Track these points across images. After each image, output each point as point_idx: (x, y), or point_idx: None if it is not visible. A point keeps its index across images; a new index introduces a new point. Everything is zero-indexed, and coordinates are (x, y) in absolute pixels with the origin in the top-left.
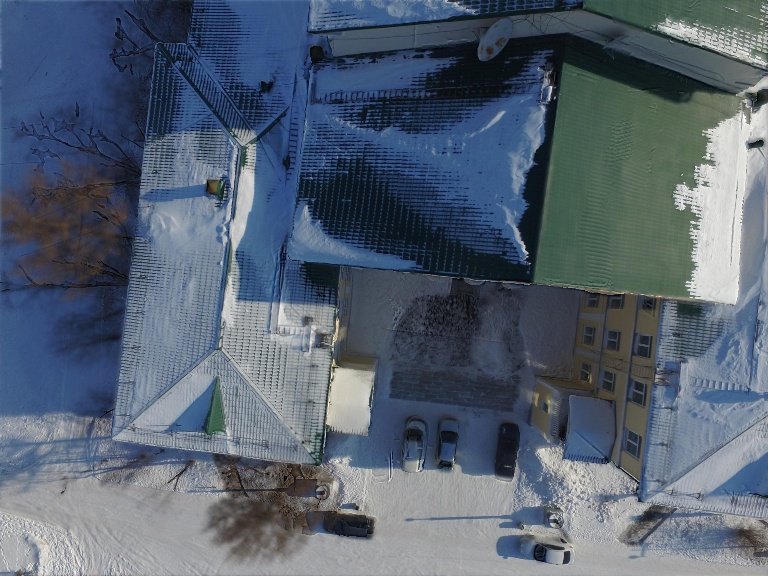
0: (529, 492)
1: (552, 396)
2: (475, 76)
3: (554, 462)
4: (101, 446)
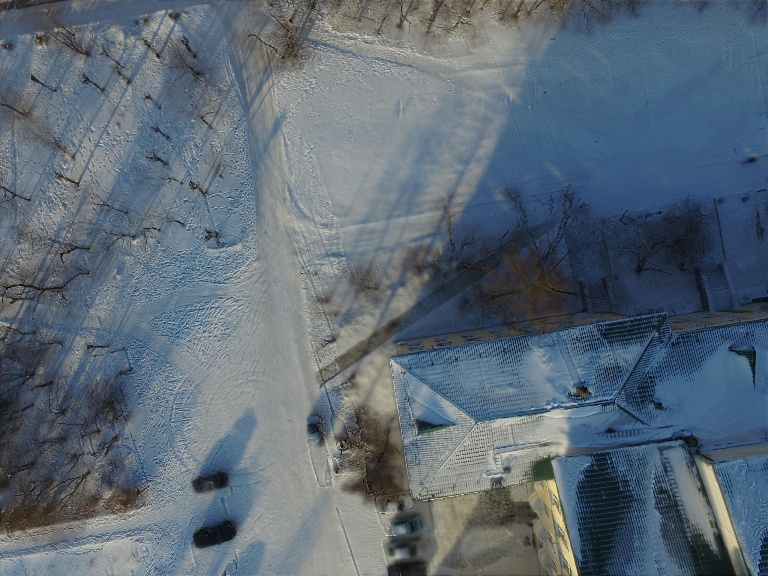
0: None
1: None
2: (710, 570)
3: None
4: (326, 267)
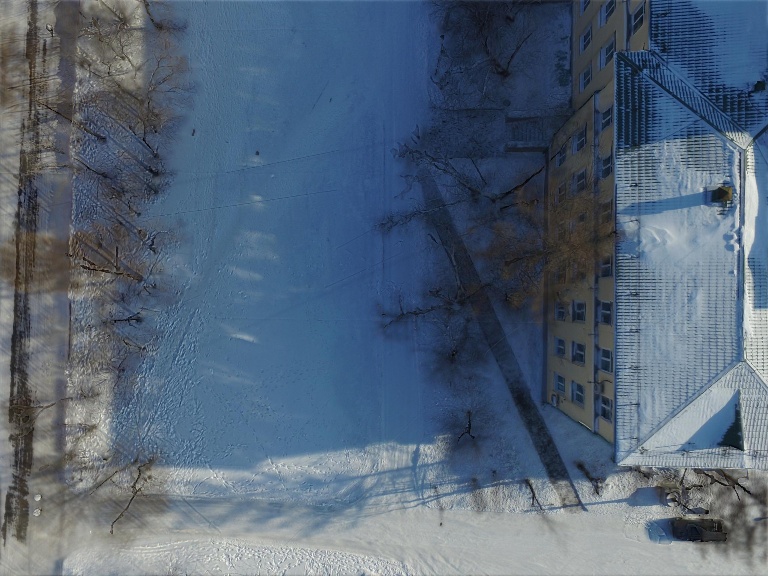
0: None
1: None
2: None
3: None
4: (428, 473)
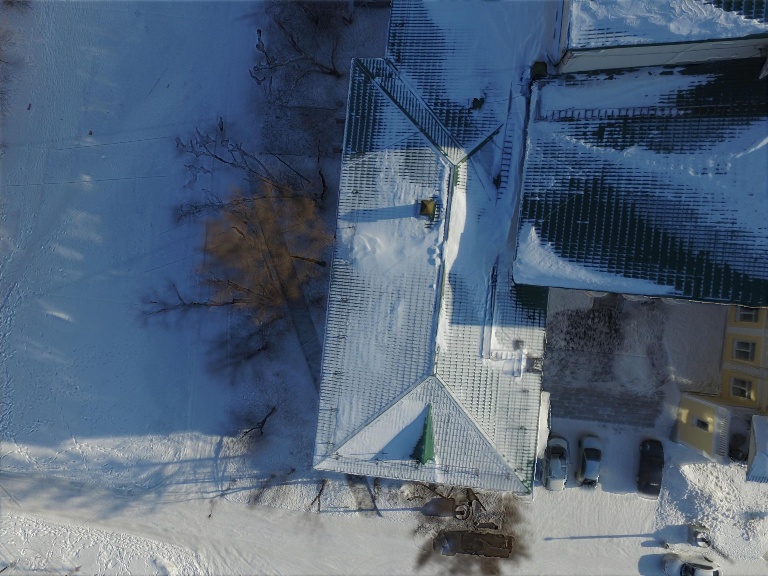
0: (672, 510)
1: (716, 414)
2: (739, 94)
3: (699, 479)
4: (229, 466)
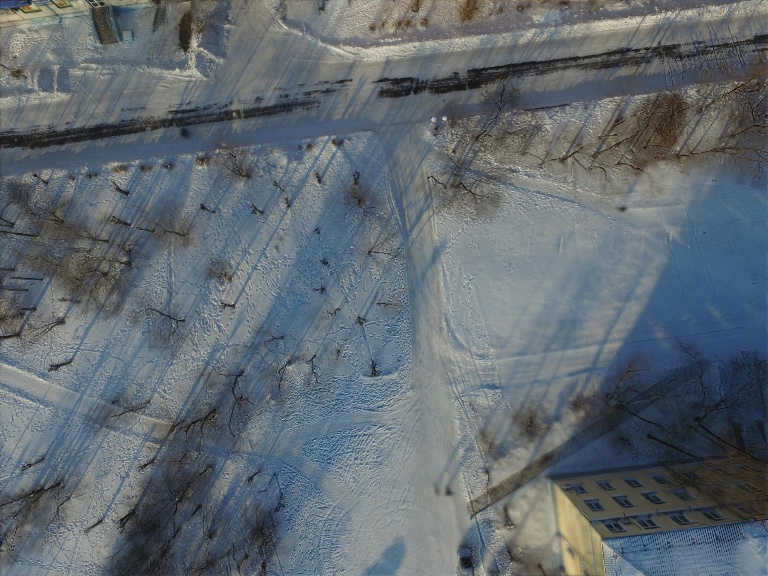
0: None
1: None
2: None
3: None
4: (480, 398)
